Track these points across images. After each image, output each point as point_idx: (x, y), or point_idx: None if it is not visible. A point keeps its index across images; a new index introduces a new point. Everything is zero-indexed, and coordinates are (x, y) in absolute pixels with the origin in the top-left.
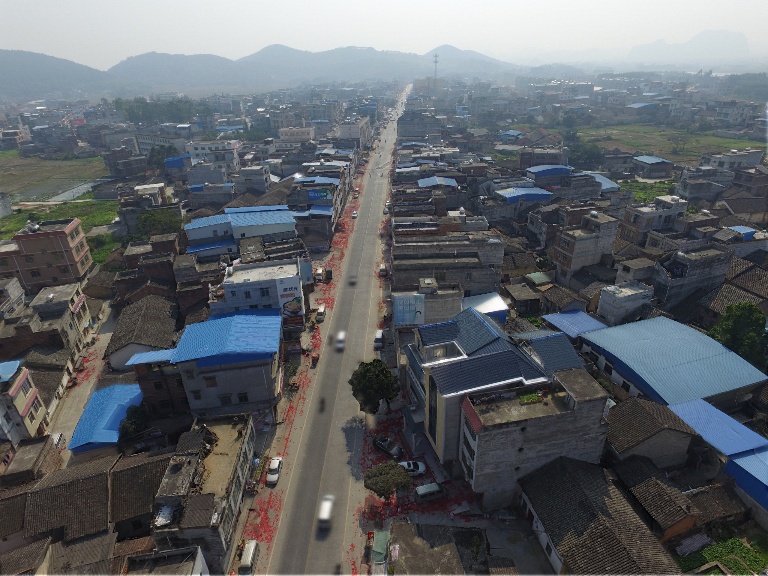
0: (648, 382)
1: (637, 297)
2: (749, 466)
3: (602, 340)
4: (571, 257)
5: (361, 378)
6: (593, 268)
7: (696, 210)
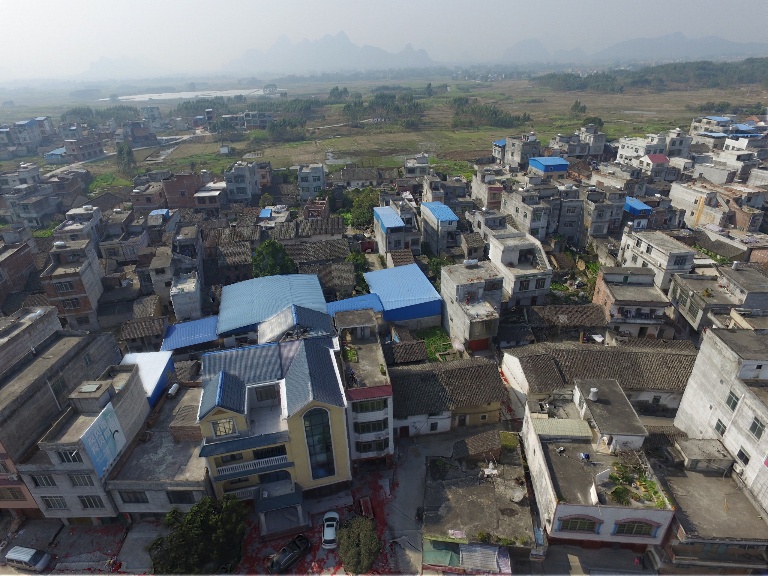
0: None
1: (197, 285)
2: (391, 307)
3: (238, 322)
4: (86, 296)
5: (206, 539)
6: (108, 296)
7: None
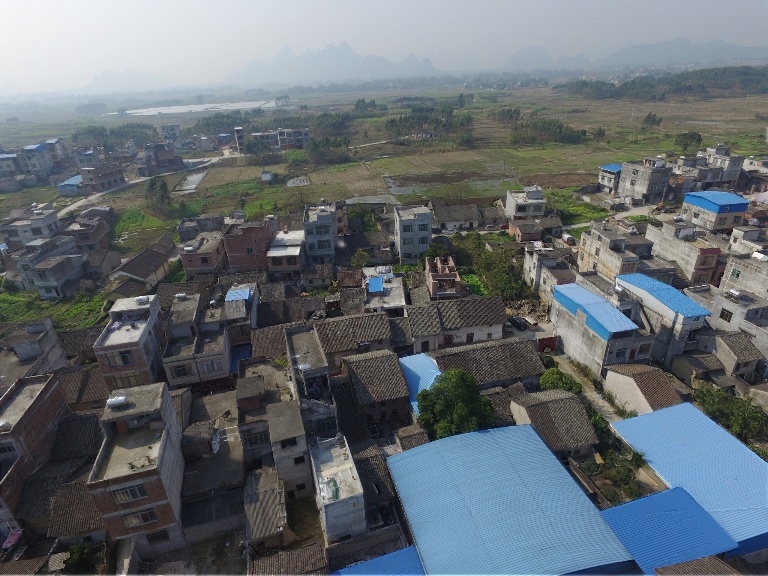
0: (595, 564)
1: None
2: (739, 531)
3: None
4: (167, 504)
5: None
6: (195, 480)
7: (88, 296)
